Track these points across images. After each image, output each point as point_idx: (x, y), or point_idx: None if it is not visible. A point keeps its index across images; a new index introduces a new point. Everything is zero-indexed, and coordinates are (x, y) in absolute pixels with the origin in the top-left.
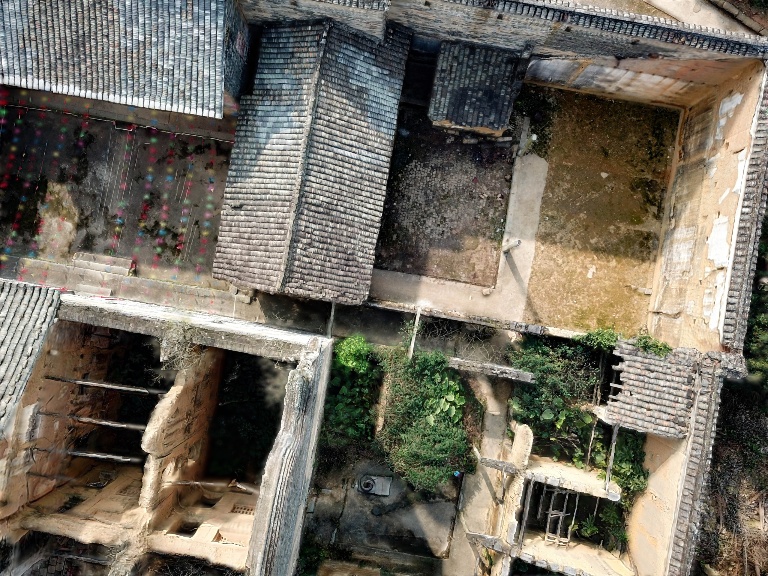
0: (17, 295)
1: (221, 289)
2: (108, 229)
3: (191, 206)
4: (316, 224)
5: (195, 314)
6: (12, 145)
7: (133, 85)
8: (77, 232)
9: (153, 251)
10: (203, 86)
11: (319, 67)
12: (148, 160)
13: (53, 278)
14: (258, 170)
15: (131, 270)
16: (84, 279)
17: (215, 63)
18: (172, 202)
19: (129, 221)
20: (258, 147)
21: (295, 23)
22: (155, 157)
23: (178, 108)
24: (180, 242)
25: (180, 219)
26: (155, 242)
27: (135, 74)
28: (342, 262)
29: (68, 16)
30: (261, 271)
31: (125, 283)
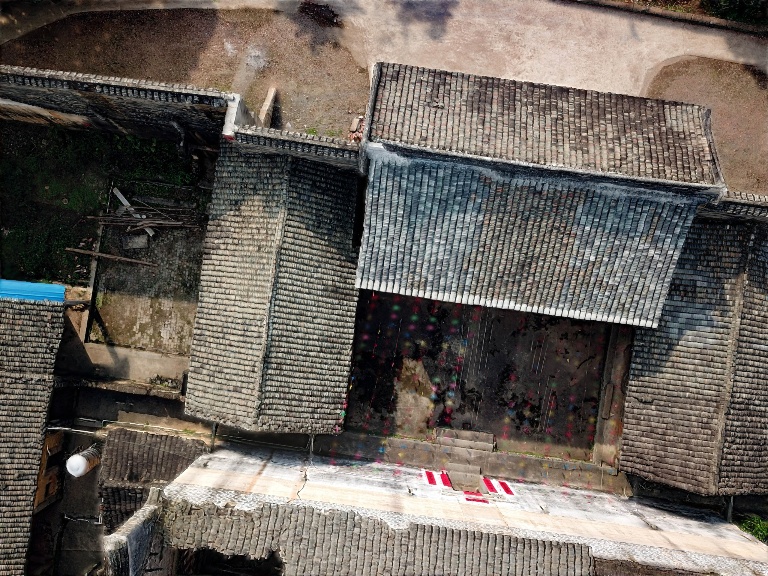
0: (553, 554)
1: (582, 459)
2: (465, 403)
3: (548, 377)
4: (738, 421)
5: (594, 502)
6: (367, 322)
7: (572, 299)
8: (435, 407)
9: (511, 423)
10: (645, 299)
11: (747, 270)
12: (503, 333)
13: (420, 457)
14: (671, 366)
15: (494, 445)
16: (451, 457)
17: (664, 279)
18: (529, 374)
19: (487, 394)
20: (669, 342)
21: (708, 220)
22: (510, 329)
23: (614, 319)
24: (538, 413)
25: (537, 390)
26: (513, 414)
27: (577, 289)
28: (757, 454)
29: (521, 240)
30: (684, 470)
31: (492, 460)
